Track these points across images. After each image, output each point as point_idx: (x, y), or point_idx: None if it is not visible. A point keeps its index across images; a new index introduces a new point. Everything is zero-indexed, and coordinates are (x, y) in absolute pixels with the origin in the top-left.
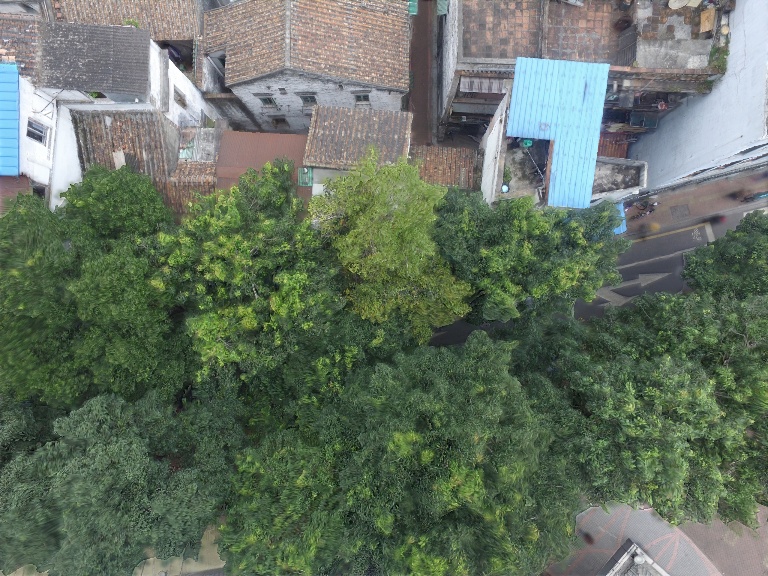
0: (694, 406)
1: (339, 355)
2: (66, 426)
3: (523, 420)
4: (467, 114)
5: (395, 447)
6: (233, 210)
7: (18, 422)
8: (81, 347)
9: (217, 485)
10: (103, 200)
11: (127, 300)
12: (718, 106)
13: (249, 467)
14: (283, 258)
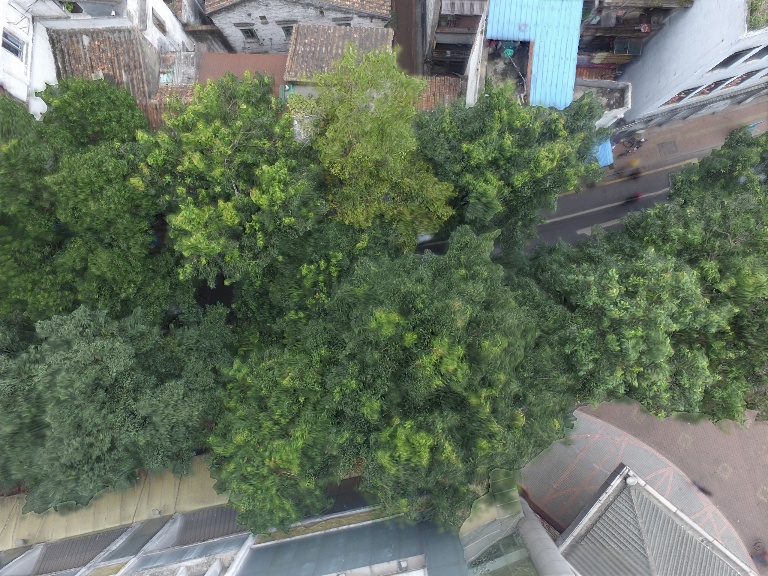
0: (678, 292)
1: (324, 263)
2: (48, 327)
3: (507, 308)
4: (451, 47)
5: (377, 325)
6: (209, 94)
7: (1, 335)
8: (63, 257)
9: (205, 403)
10: (79, 99)
11: (106, 198)
12: (700, 17)
13: (236, 375)
14: (263, 157)
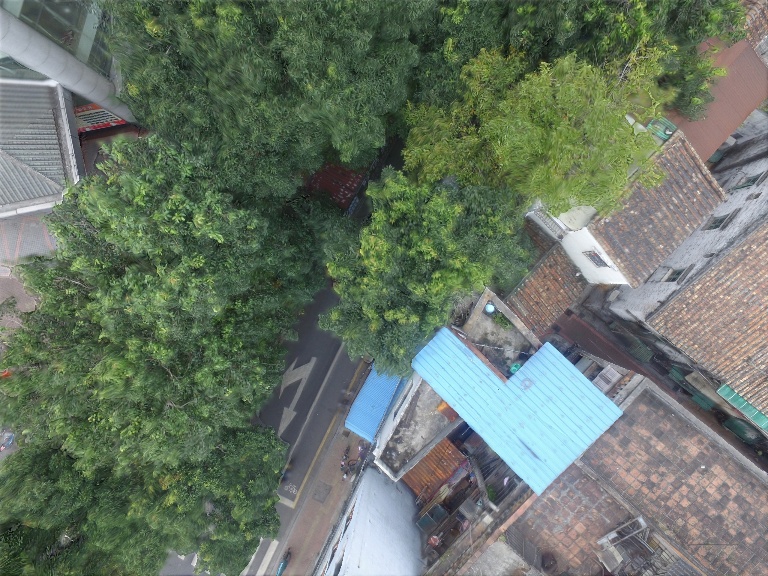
0: None
1: (463, 3)
2: None
3: None
4: None
5: None
6: None
7: None
8: None
9: None
10: None
11: None
12: None
13: None
14: None
